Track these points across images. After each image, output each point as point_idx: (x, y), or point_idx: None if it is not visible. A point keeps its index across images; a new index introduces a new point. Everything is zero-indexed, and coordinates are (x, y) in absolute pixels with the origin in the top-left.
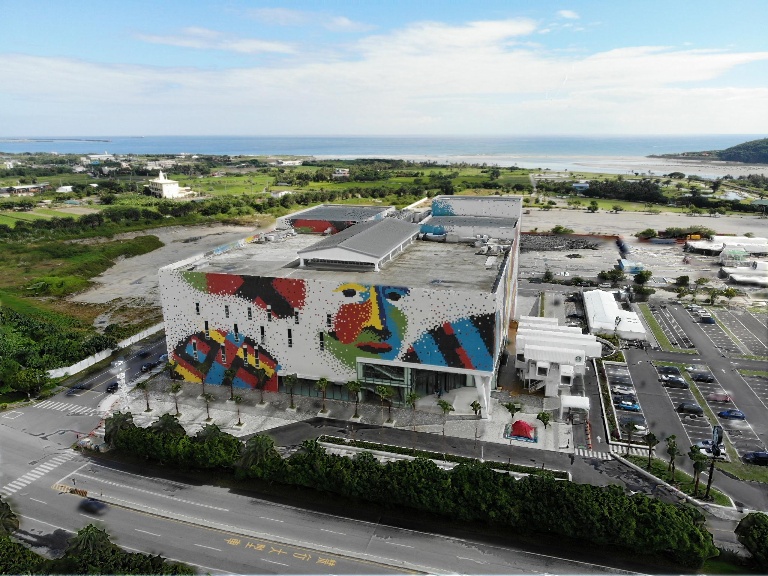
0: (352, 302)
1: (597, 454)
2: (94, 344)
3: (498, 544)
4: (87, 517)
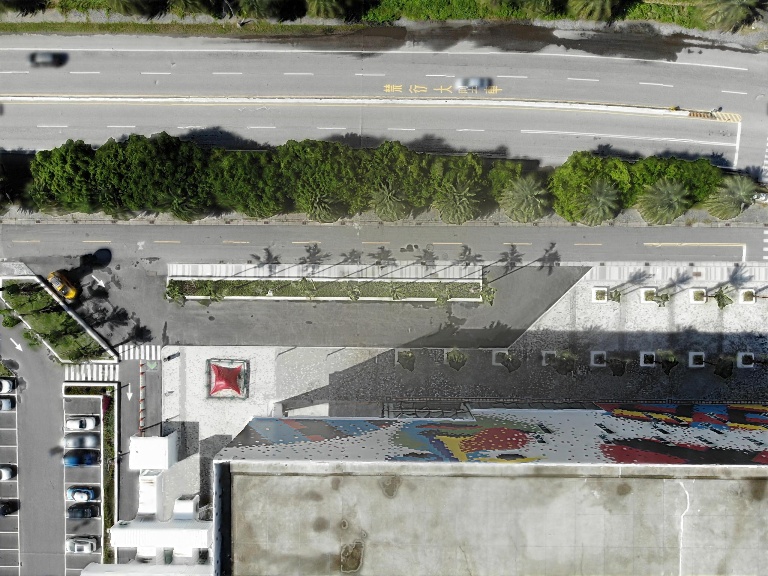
0: (503, 451)
1: (135, 353)
2: None
3: None
4: (662, 83)
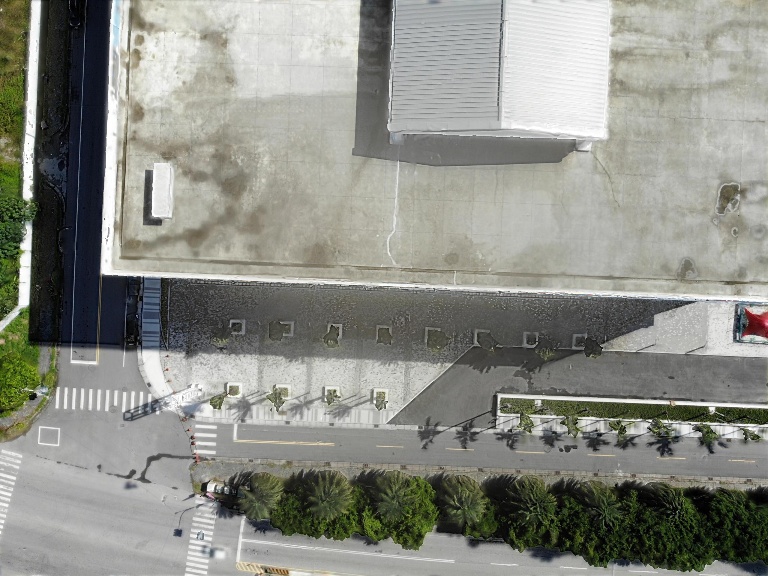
0: None
1: None
2: (3, 239)
3: None
4: None
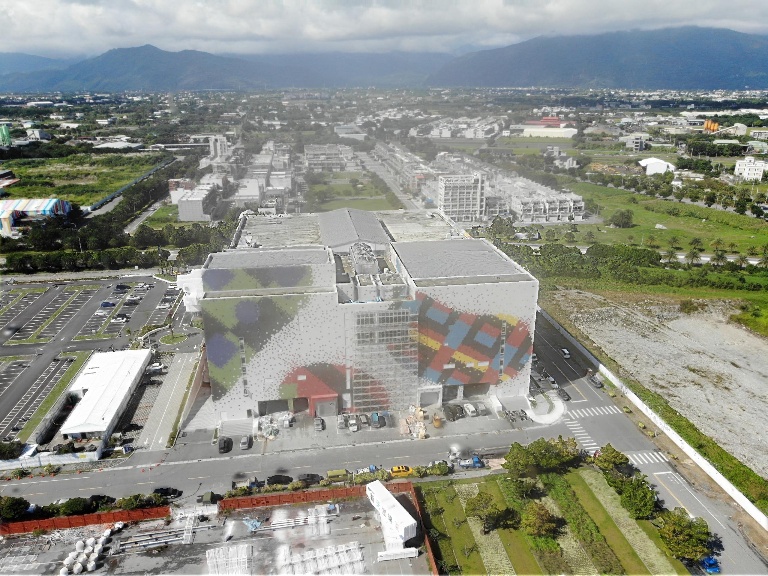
0: None
1: None
2: None
3: None
4: None
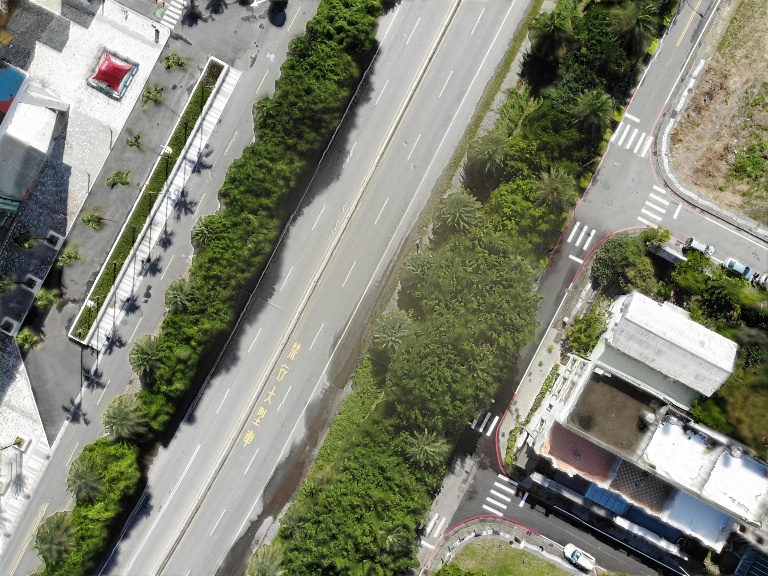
0: None
1: (178, 3)
2: None
3: (305, 185)
4: None
